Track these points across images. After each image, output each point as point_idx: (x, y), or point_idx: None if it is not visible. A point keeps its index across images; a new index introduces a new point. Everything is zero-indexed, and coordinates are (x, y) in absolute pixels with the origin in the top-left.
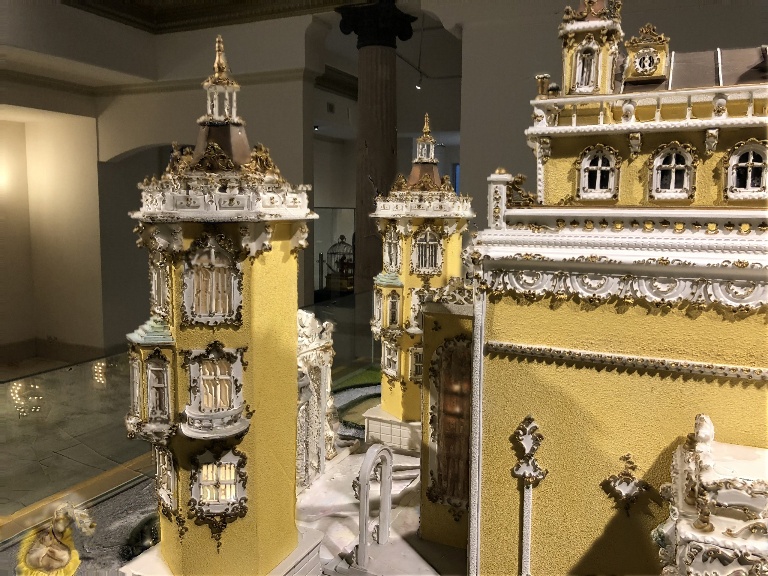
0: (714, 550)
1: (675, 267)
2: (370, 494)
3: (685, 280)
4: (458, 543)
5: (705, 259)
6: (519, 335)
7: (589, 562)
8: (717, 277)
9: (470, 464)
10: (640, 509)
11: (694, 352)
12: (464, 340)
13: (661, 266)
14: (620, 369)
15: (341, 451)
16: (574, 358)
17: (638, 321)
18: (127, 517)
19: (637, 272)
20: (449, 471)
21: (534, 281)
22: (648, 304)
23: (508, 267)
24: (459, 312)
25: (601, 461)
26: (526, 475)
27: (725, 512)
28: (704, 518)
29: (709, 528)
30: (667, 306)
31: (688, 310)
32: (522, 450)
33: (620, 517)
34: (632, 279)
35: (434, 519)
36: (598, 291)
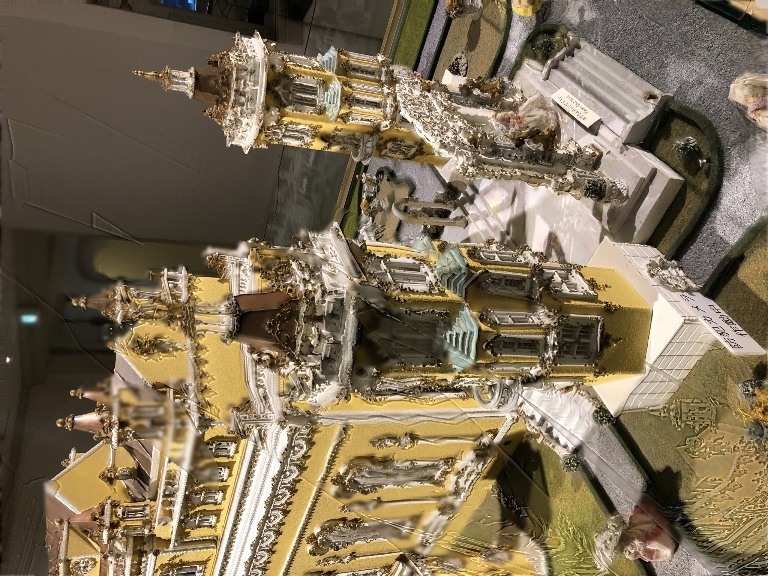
0: None
1: None
2: (531, 228)
3: None
4: None
5: None
6: None
7: None
8: None
9: None
10: None
11: None
12: None
13: None
14: None
15: (585, 204)
16: None
17: None
18: (572, 1)
19: None
20: None
21: None
22: None
23: None
24: None
25: None
26: None
27: None
28: None
29: None
30: None
31: None
32: None
33: None
34: None
35: None
36: None
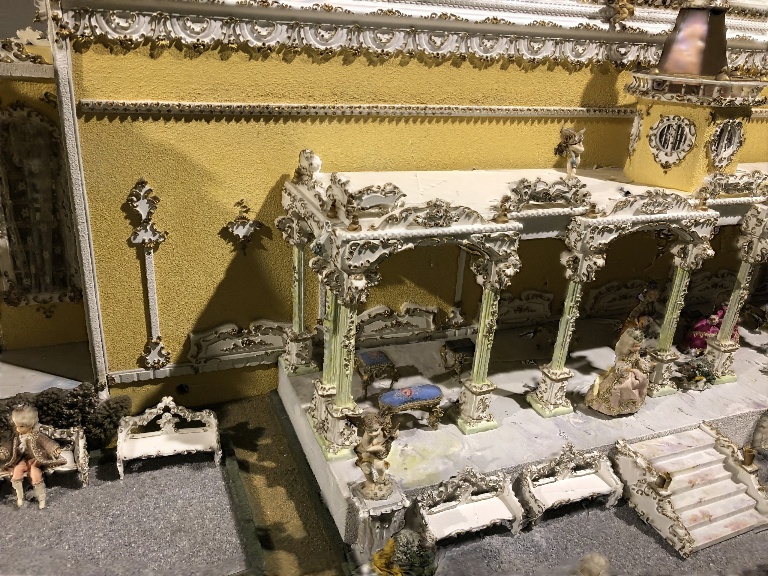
0: (367, 243)
1: (274, 9)
2: None
3: (281, 23)
4: (54, 340)
5: (298, 2)
6: (118, 90)
7: (214, 306)
8: (308, 20)
9: (78, 245)
10: (255, 246)
11: (291, 95)
12: (23, 108)
13: (262, 8)
14: (228, 118)
15: None
16: (183, 111)
17: (241, 67)
18: None
19: (239, 14)
20: (31, 266)
21: (130, 24)
22: (249, 49)
23: (95, 5)
24: (9, 72)
25: (218, 211)
26: (146, 241)
27: (365, 215)
28: (356, 221)
29: (360, 228)
30: (267, 50)
31: (284, 54)
32: (138, 217)
33: (238, 258)
34: (234, 22)
35: (19, 324)
36: (201, 36)
